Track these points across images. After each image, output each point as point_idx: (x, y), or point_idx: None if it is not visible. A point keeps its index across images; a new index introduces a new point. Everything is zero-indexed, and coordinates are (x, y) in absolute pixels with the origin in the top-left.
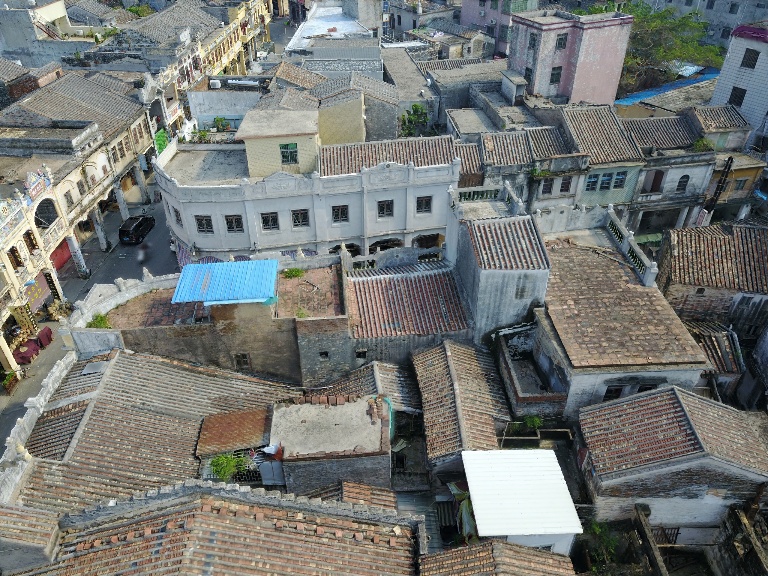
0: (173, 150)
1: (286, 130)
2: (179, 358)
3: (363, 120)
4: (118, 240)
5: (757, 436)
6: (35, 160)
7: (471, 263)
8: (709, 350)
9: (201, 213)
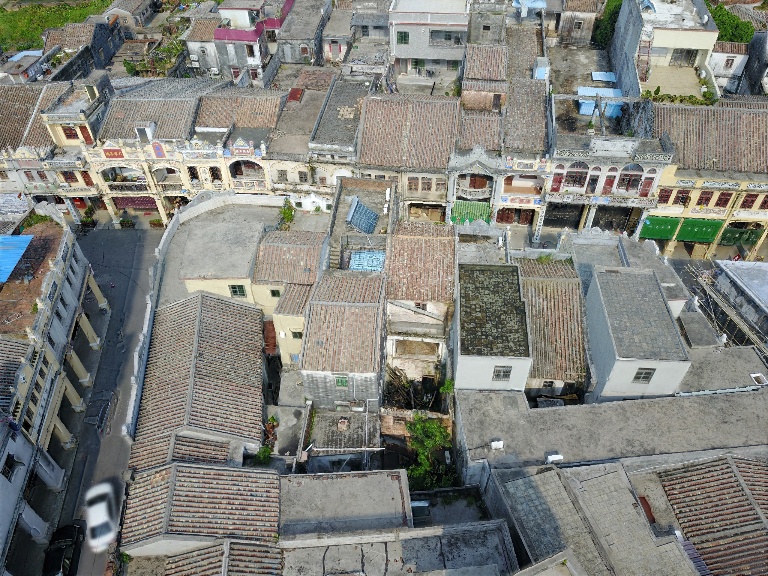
0: (277, 202)
1: (194, 255)
2: None
3: None
4: None
5: None
6: None
7: None
8: None
9: None
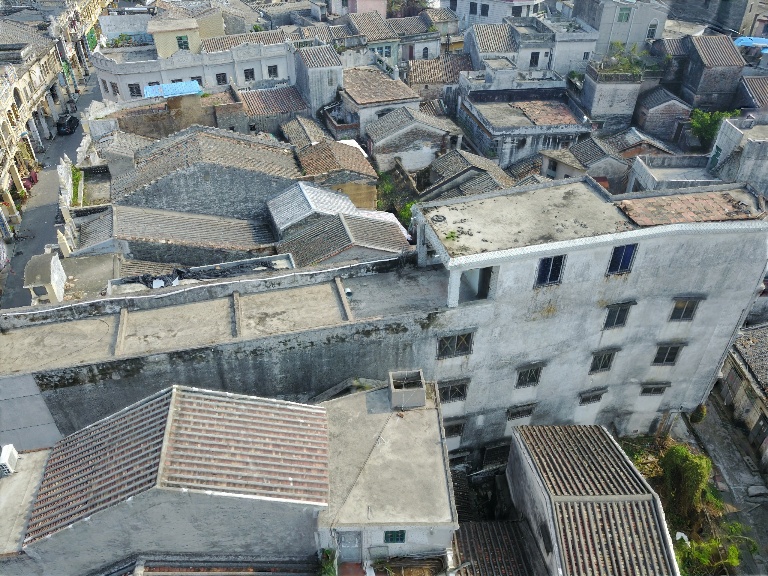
0: None
1: (179, 27)
2: (151, 137)
3: (224, 28)
4: (55, 133)
5: (444, 124)
6: None
7: (303, 71)
8: (429, 107)
9: (132, 82)
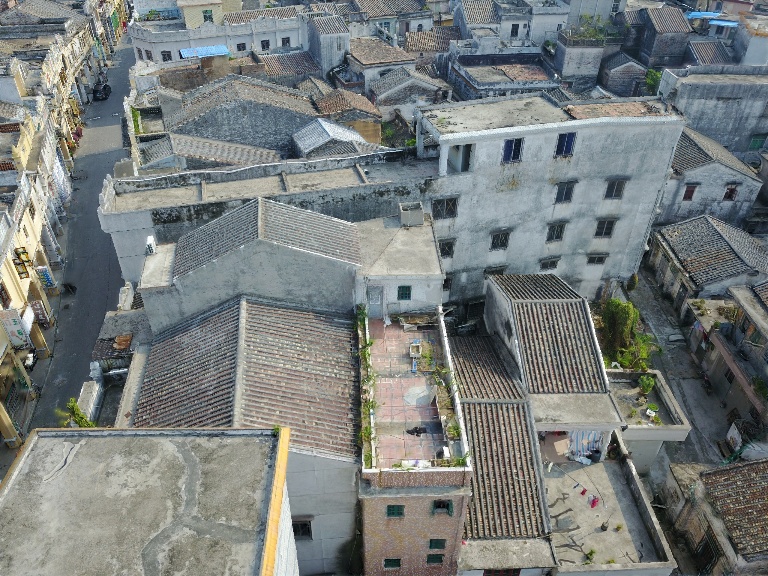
0: None
1: (205, 2)
2: None
3: (242, 5)
4: (91, 99)
5: None
6: (41, 39)
7: (315, 38)
8: (424, 71)
9: (165, 50)
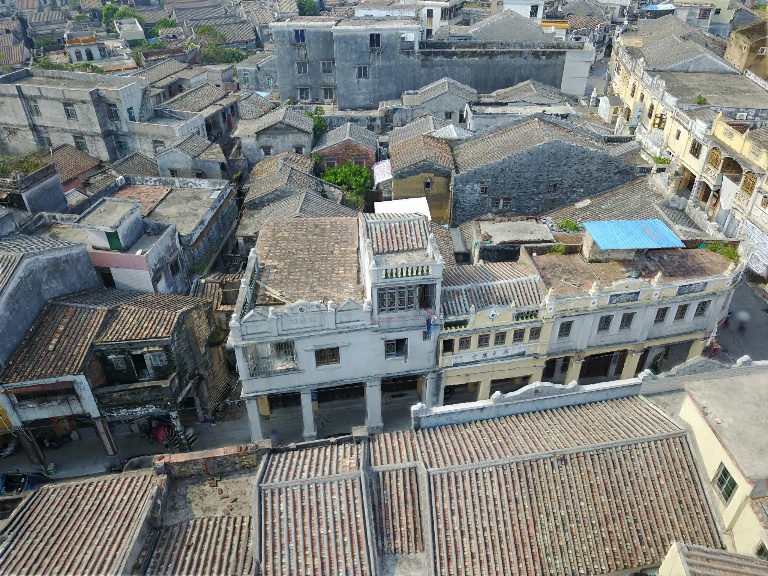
0: None
1: (748, 388)
2: None
3: None
4: None
5: None
6: None
7: None
8: None
9: None
